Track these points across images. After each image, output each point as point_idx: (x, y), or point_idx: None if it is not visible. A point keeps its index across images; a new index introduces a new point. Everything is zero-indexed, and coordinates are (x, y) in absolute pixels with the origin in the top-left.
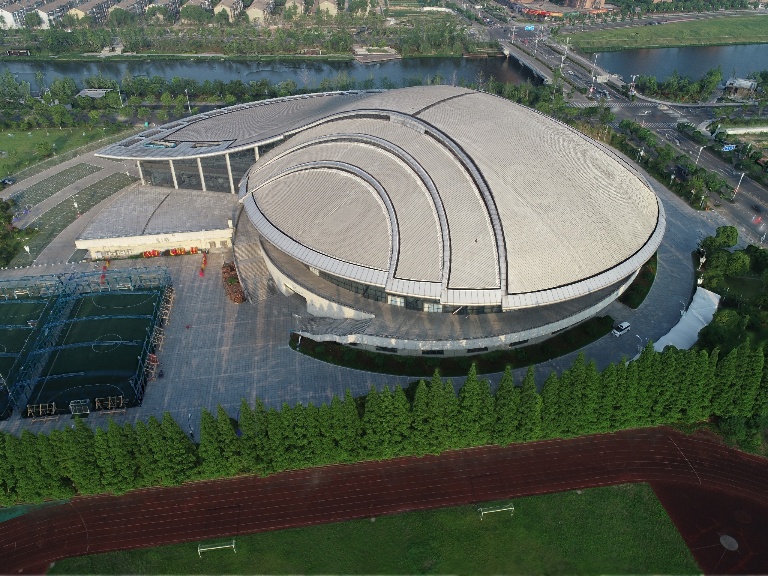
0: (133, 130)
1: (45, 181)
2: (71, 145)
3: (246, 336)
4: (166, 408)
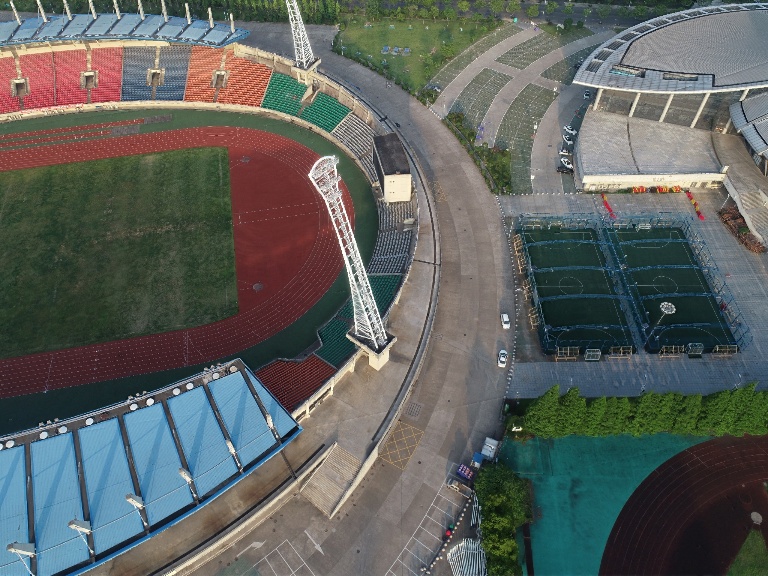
0: (506, 27)
1: (468, 90)
2: (459, 43)
3: None
4: (764, 357)
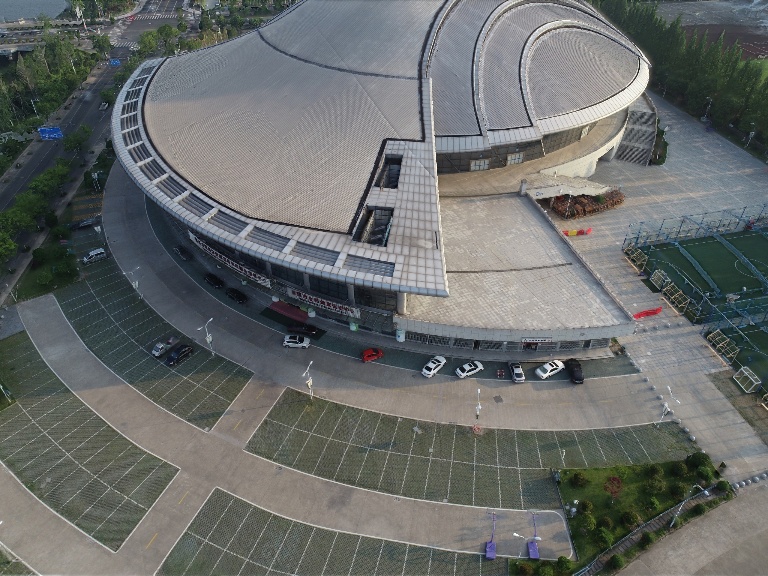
0: None
1: None
2: None
3: (667, 187)
4: None
